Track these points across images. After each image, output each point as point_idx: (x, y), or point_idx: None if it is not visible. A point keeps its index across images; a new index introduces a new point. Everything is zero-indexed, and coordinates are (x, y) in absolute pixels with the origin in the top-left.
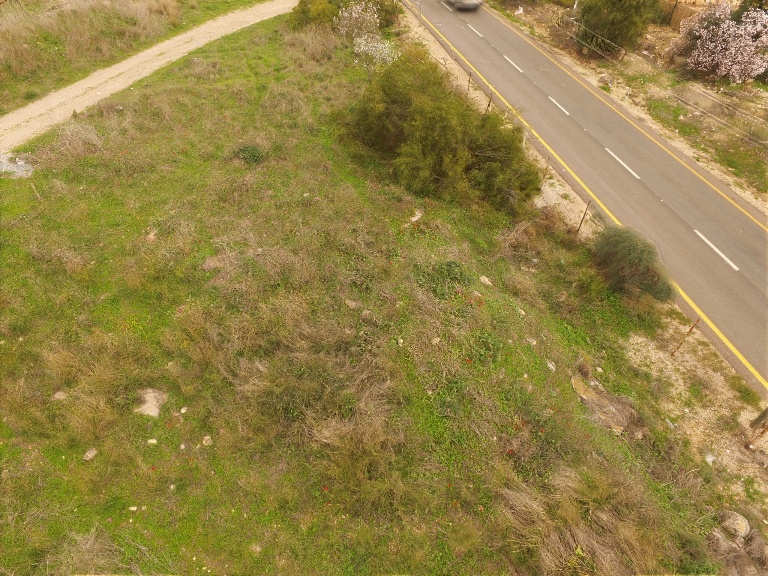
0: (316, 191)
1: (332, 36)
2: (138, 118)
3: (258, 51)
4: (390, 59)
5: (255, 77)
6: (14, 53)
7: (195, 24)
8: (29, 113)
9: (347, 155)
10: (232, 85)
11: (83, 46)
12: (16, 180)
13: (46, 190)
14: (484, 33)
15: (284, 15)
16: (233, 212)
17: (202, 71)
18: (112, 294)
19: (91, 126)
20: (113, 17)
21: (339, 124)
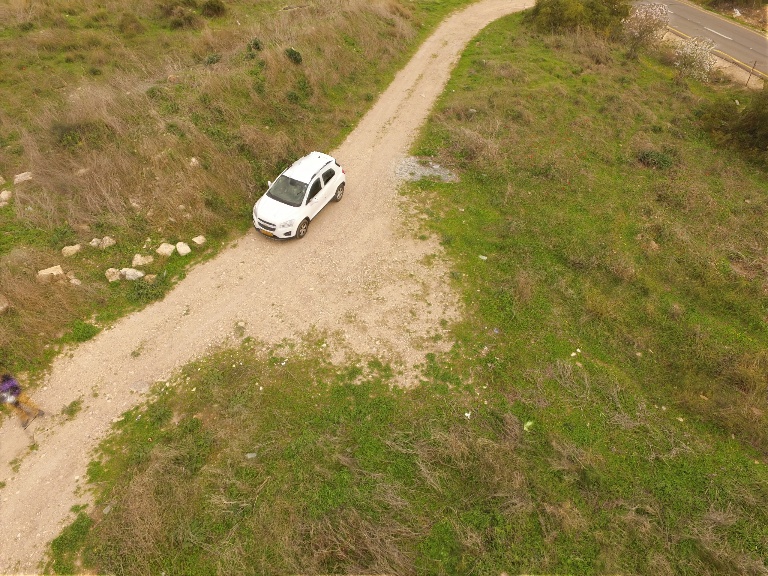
0: (756, 198)
1: (594, 38)
2: (504, 121)
3: (531, 53)
4: (707, 62)
5: (560, 80)
6: (335, 54)
7: (432, 25)
8: (381, 115)
9: (742, 160)
10: (552, 88)
11: (374, 47)
12: (455, 184)
13: (499, 195)
14: (730, 36)
15: (512, 17)
16: (706, 219)
17: (513, 73)
18: (685, 304)
19: (468, 129)
20: (377, 18)
21: (701, 128)
